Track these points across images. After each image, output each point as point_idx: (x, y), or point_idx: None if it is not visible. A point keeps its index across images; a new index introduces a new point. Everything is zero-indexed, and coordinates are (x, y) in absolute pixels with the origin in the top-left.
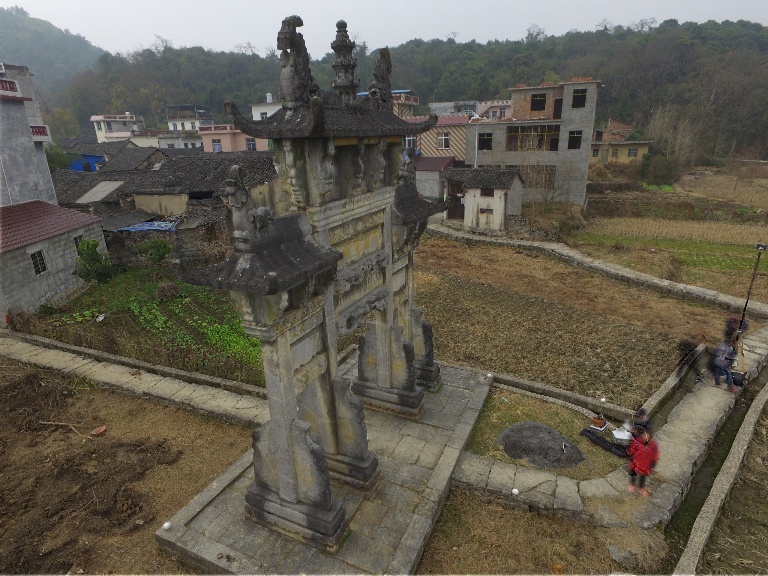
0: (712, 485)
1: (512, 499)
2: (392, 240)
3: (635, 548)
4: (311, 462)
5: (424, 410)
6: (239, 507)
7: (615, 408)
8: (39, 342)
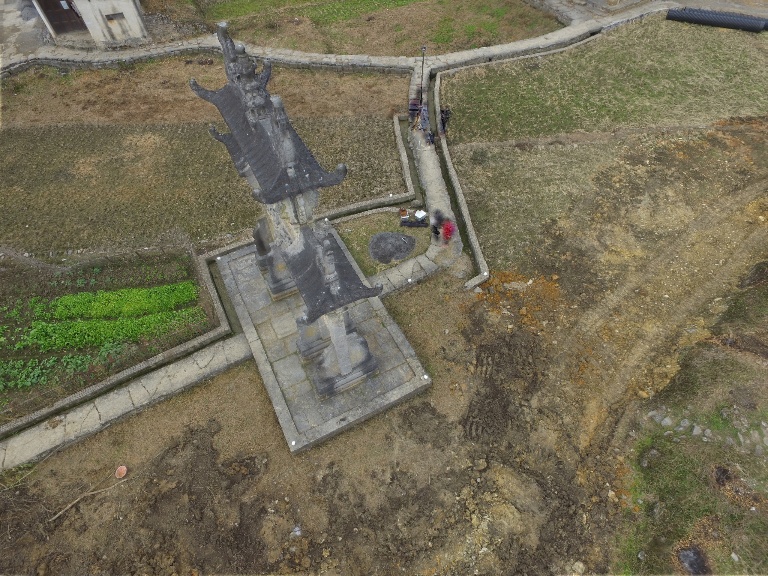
0: (461, 214)
1: (409, 285)
2: None
3: (463, 267)
4: (360, 348)
5: None
6: (309, 402)
7: (399, 197)
8: None
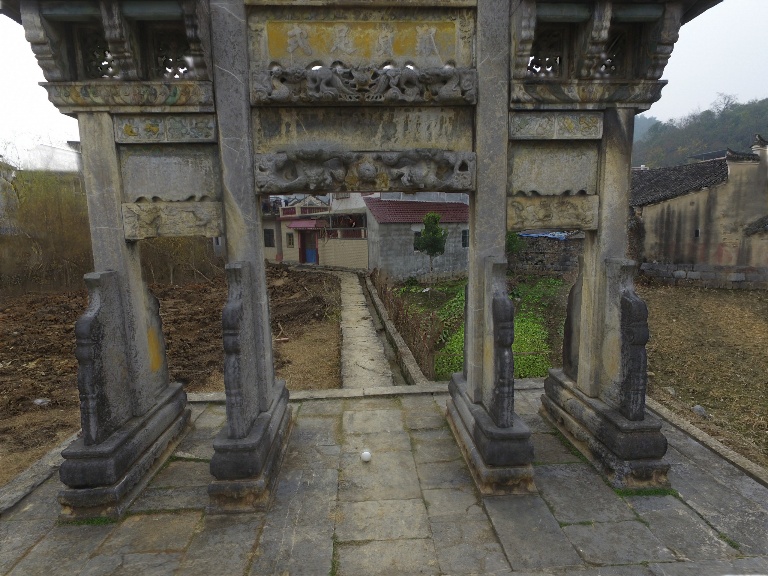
0: None
1: None
2: (510, 54)
3: None
4: None
5: (527, 493)
6: None
7: None
8: (371, 293)
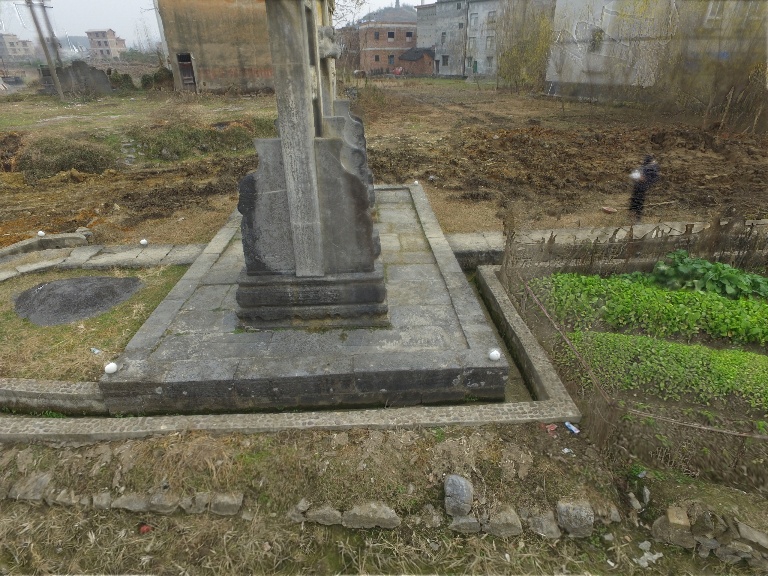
0: None
1: None
2: None
3: None
4: None
5: None
6: None
7: None
8: None
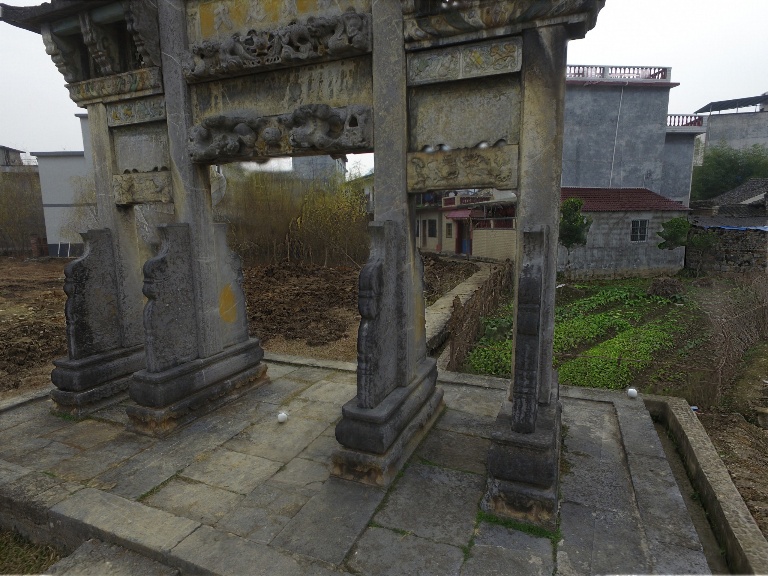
0: None
1: None
2: None
3: None
4: None
5: (374, 485)
6: None
7: None
8: None
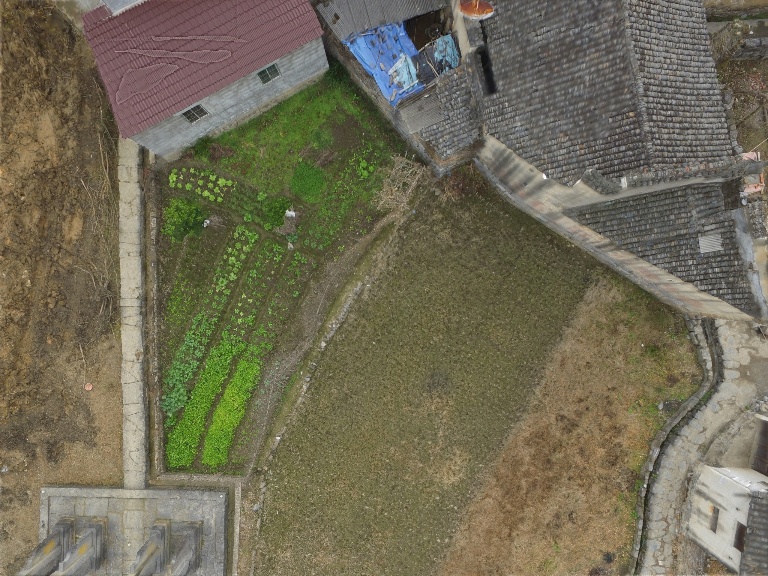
0: None
1: None
2: None
3: None
4: None
5: None
6: (67, 510)
7: None
8: None
